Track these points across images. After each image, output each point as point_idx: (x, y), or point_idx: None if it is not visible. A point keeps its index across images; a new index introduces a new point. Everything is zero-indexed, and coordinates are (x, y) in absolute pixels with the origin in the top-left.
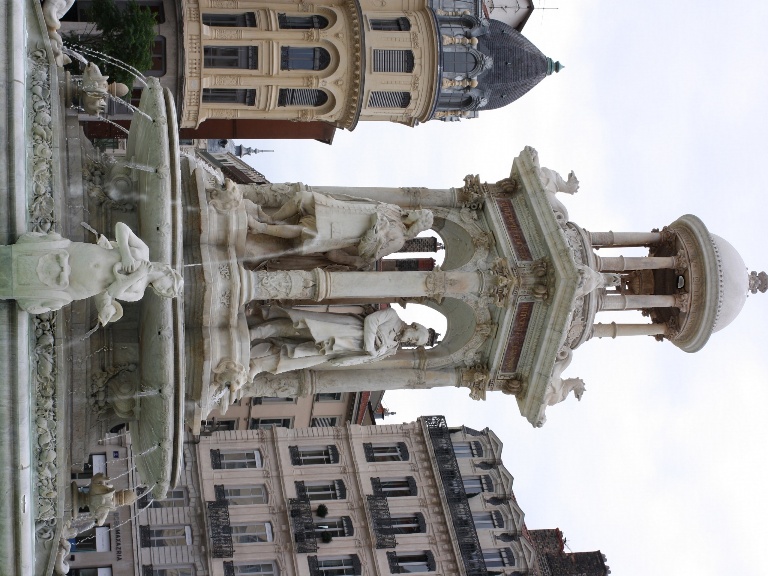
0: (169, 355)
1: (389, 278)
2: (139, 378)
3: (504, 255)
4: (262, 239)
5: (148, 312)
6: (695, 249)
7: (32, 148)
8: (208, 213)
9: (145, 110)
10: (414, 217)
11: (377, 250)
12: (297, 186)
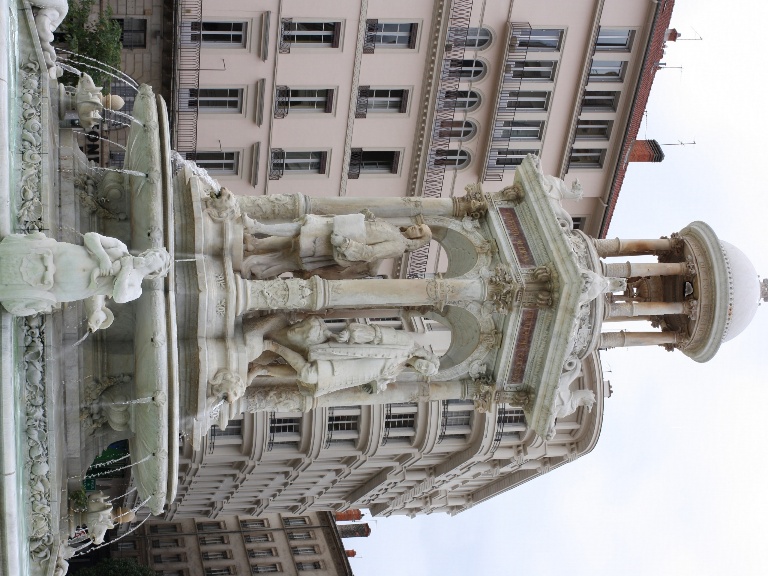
0: None
1: None
2: None
3: (497, 374)
4: (262, 358)
5: (137, 467)
6: (702, 337)
7: (30, 504)
8: None
9: None
10: None
11: None
12: (314, 304)
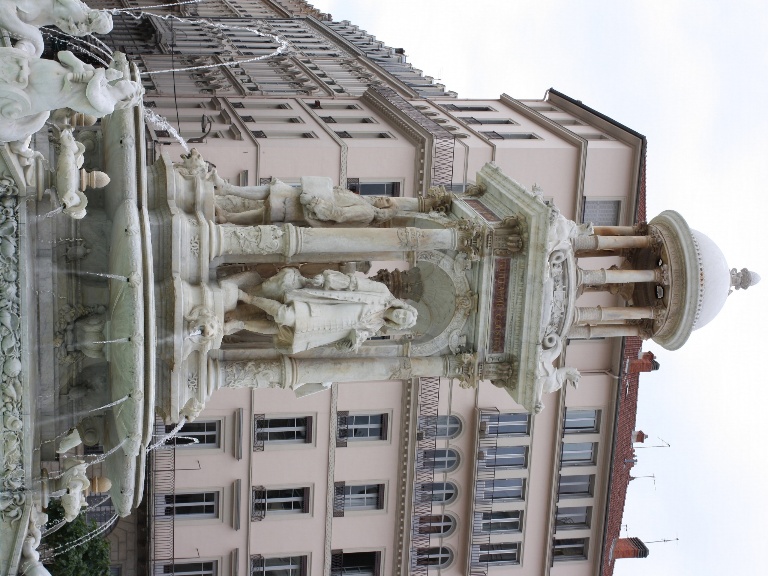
0: (129, 503)
1: (354, 377)
2: (103, 431)
3: (478, 342)
4: (238, 317)
5: None
6: (679, 307)
7: (2, 416)
8: (182, 355)
9: (122, 352)
10: (397, 322)
11: (350, 352)
12: (287, 245)
